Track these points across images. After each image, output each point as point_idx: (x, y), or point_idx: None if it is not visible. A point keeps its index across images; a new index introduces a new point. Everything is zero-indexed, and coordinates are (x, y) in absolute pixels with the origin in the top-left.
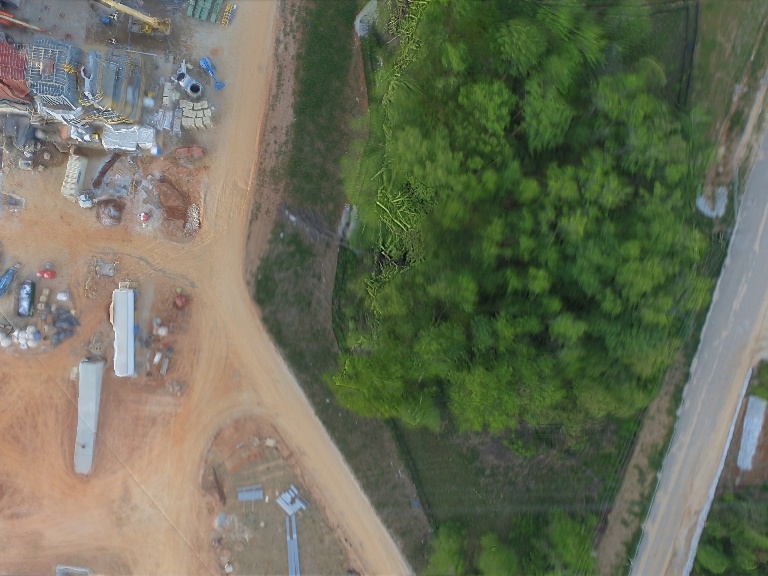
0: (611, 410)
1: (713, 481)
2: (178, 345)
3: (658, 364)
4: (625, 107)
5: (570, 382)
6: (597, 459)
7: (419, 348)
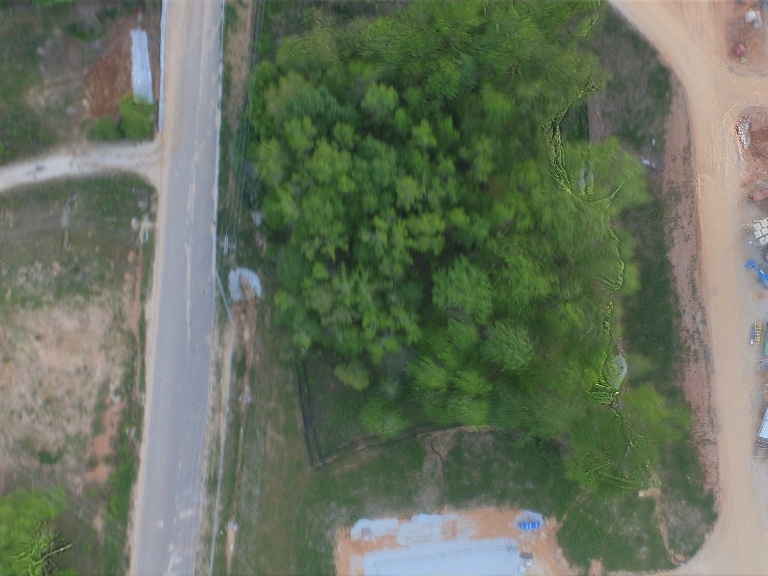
0: (292, 51)
1: (168, 8)
2: (732, 8)
3: (259, 107)
4: (383, 326)
5: (347, 63)
6: (286, 5)
7: (522, 44)
